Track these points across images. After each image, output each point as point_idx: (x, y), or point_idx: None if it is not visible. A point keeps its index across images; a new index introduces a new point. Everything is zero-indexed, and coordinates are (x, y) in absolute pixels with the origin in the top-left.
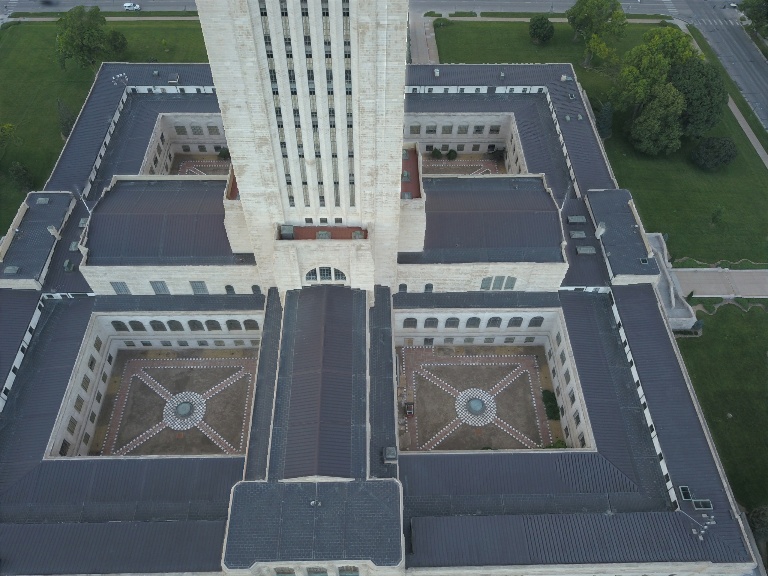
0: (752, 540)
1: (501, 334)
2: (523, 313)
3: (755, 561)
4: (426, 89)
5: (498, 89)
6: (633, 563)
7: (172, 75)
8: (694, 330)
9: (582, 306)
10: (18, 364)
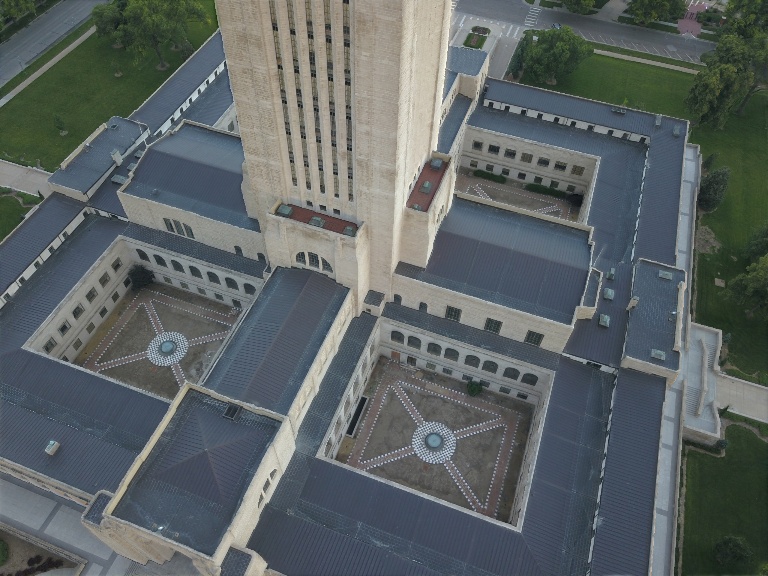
0: None
1: None
2: None
3: None
4: None
5: None
6: None
7: None
8: None
9: None
10: None
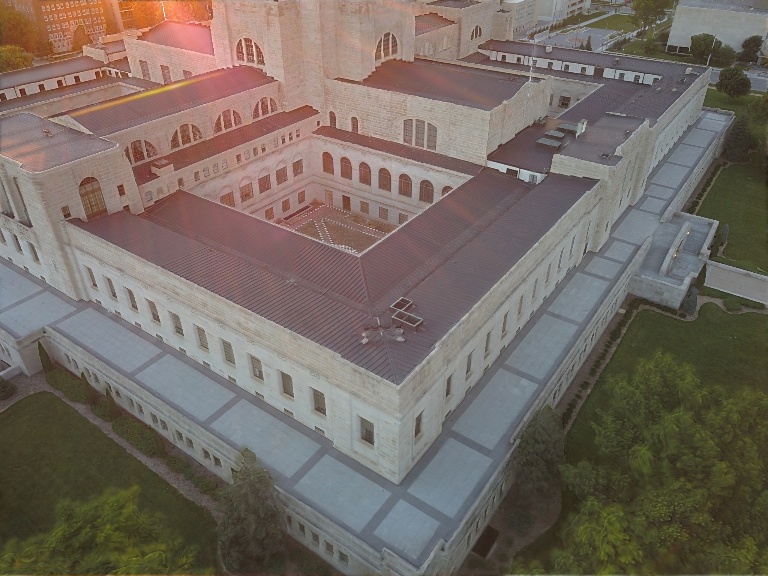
0: (497, 469)
1: (413, 210)
2: (431, 173)
3: (400, 384)
4: (530, 60)
5: (606, 72)
6: (249, 310)
7: None
8: (682, 311)
9: (502, 186)
10: (48, 88)
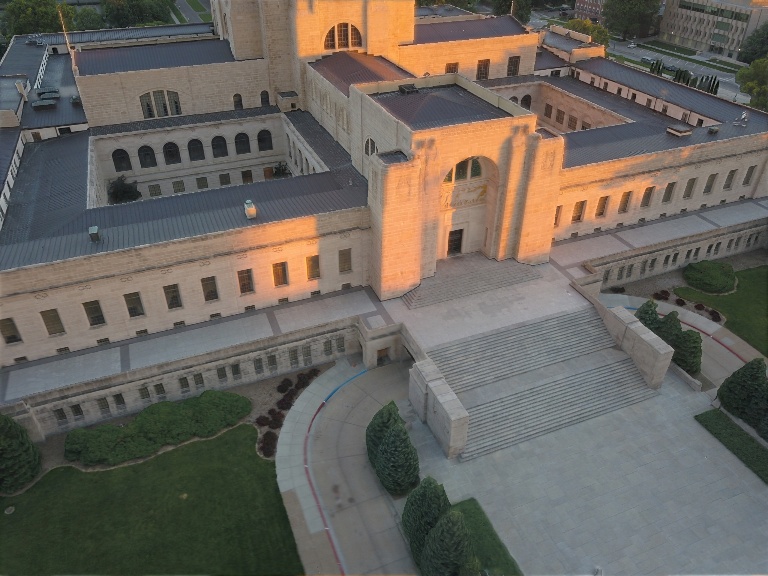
0: None
1: None
2: None
3: (14, 36)
4: None
5: None
6: None
7: (685, 128)
8: None
9: None
10: None
